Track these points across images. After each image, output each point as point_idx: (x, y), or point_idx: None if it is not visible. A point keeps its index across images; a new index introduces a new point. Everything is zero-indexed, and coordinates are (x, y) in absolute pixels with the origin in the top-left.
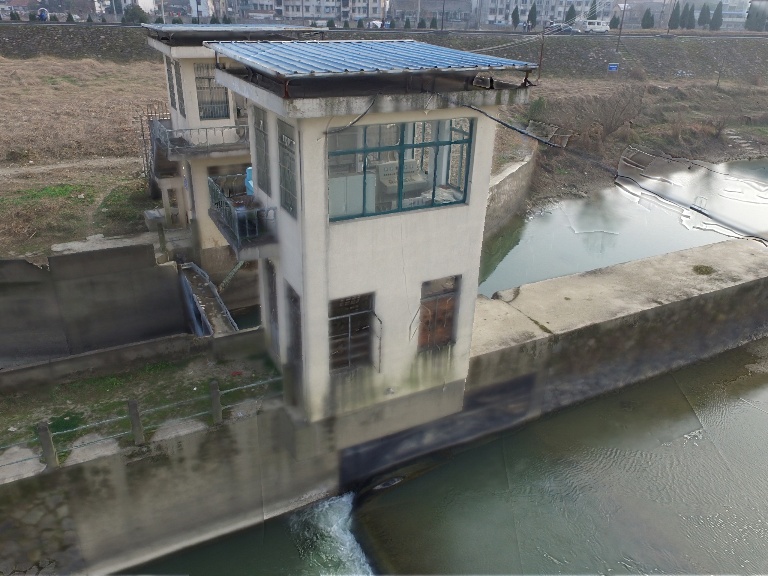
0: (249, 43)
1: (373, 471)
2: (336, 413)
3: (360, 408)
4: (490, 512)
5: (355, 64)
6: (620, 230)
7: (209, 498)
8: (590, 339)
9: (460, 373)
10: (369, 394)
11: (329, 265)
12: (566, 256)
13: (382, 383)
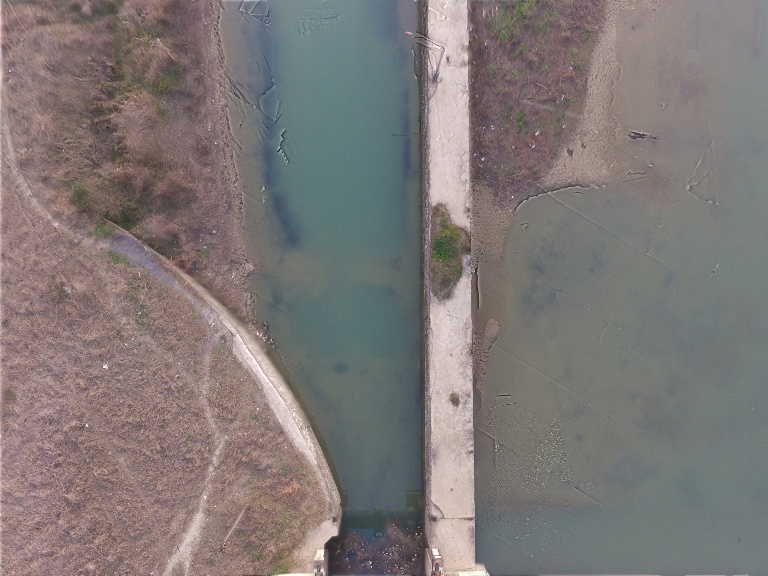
0: None
1: None
2: None
3: None
4: (494, 545)
5: None
6: (312, 289)
7: None
8: None
9: None
10: None
11: None
12: (335, 363)
13: None
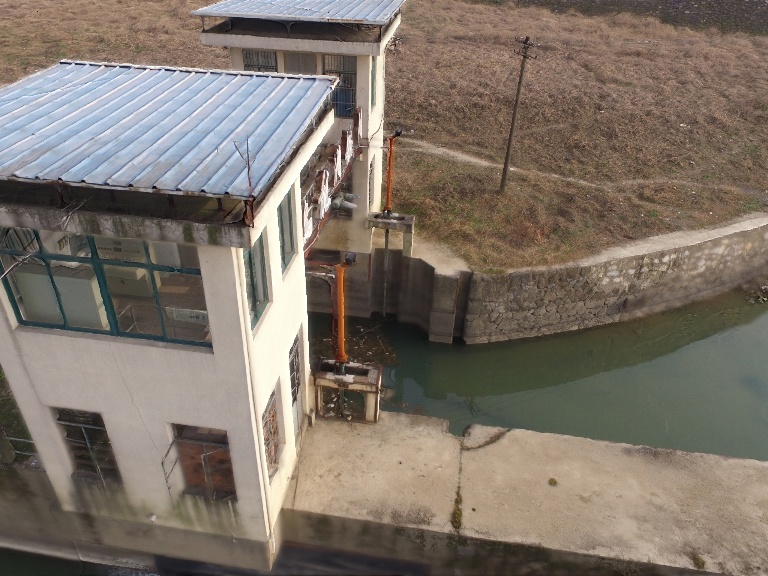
0: (106, 67)
1: (197, 571)
2: (91, 512)
3: (120, 518)
4: None
5: (4, 149)
6: None
7: (19, 520)
8: (531, 561)
9: (254, 533)
10: (128, 510)
11: (29, 370)
12: (762, 378)
13: (142, 505)
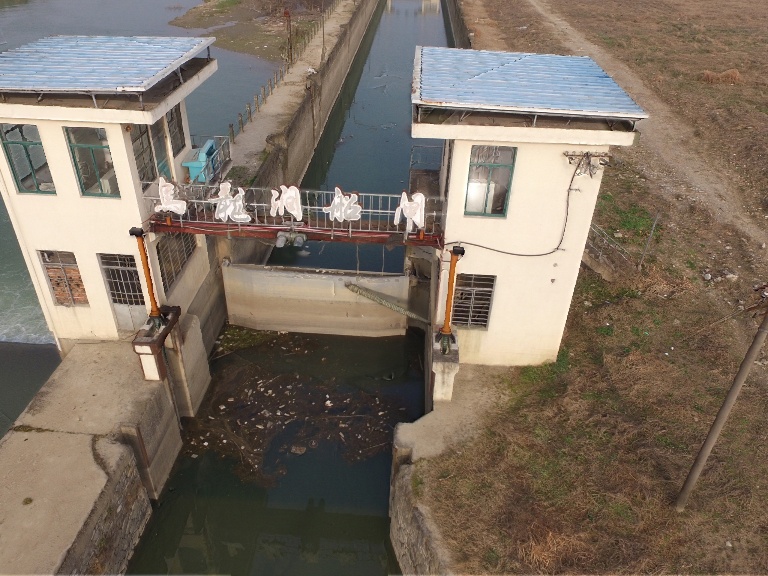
0: None
1: None
2: None
3: None
4: None
5: None
6: None
7: None
8: None
9: None
10: None
11: None
12: None
13: None
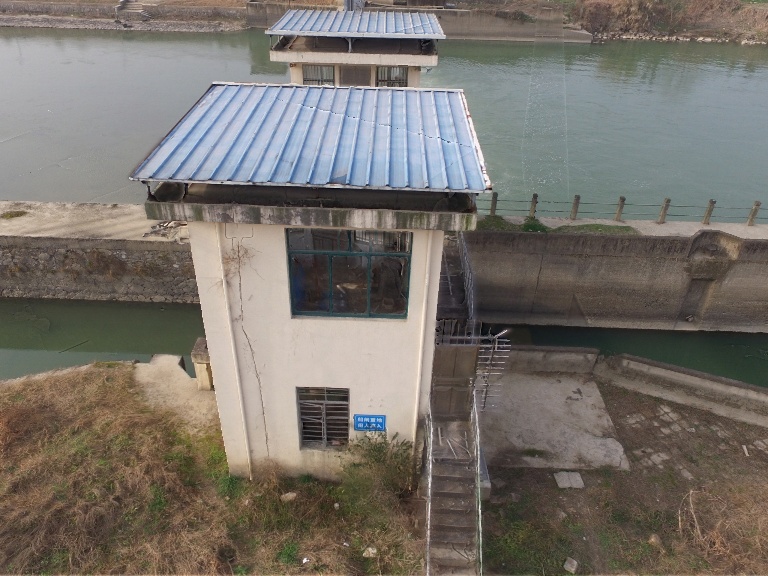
0: None
1: None
2: None
3: None
4: None
5: None
6: None
7: None
8: None
9: None
10: None
11: None
12: None
13: None
